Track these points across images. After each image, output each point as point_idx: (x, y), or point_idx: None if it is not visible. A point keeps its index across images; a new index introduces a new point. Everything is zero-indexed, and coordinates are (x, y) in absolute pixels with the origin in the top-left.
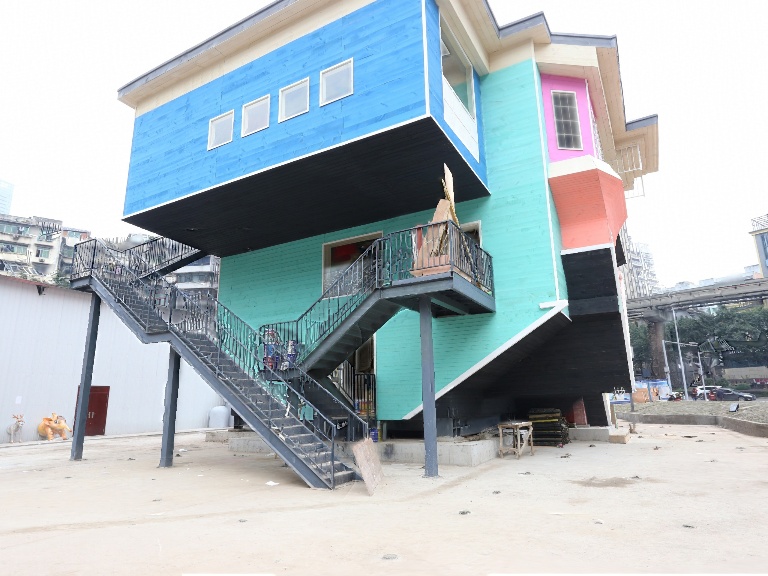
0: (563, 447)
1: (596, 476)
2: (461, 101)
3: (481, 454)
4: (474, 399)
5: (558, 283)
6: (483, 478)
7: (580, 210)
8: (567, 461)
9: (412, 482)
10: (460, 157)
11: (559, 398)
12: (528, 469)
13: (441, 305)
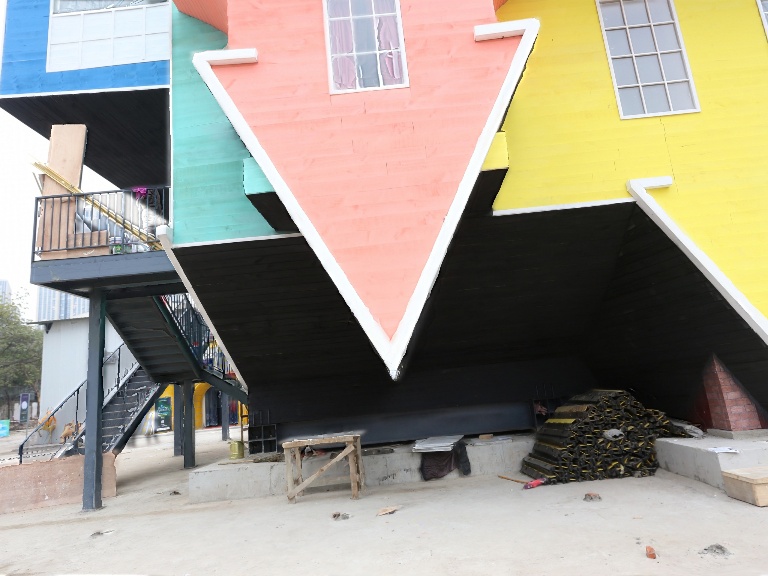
0: (529, 488)
1: (43, 573)
2: (115, 8)
3: (230, 486)
4: (348, 390)
5: (183, 194)
6: (68, 526)
7: (226, 14)
8: (276, 527)
9: (54, 512)
10: (88, 94)
11: (663, 361)
12: (157, 527)
13: (159, 283)
